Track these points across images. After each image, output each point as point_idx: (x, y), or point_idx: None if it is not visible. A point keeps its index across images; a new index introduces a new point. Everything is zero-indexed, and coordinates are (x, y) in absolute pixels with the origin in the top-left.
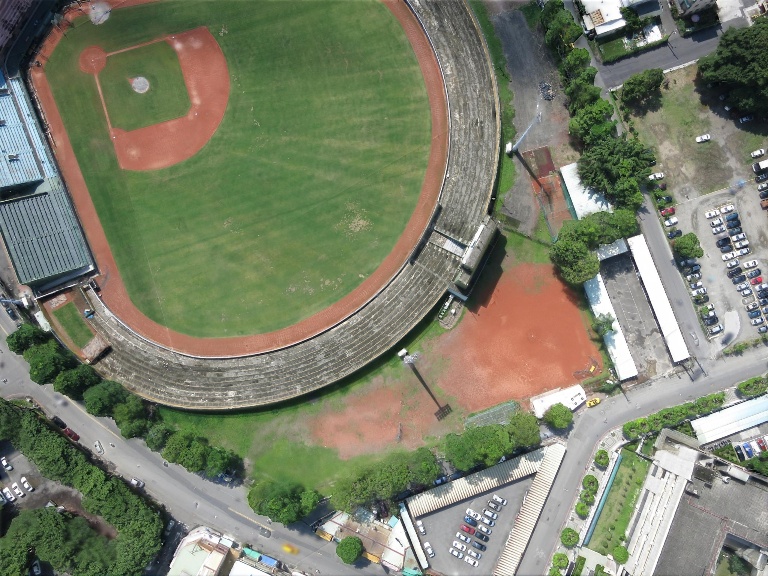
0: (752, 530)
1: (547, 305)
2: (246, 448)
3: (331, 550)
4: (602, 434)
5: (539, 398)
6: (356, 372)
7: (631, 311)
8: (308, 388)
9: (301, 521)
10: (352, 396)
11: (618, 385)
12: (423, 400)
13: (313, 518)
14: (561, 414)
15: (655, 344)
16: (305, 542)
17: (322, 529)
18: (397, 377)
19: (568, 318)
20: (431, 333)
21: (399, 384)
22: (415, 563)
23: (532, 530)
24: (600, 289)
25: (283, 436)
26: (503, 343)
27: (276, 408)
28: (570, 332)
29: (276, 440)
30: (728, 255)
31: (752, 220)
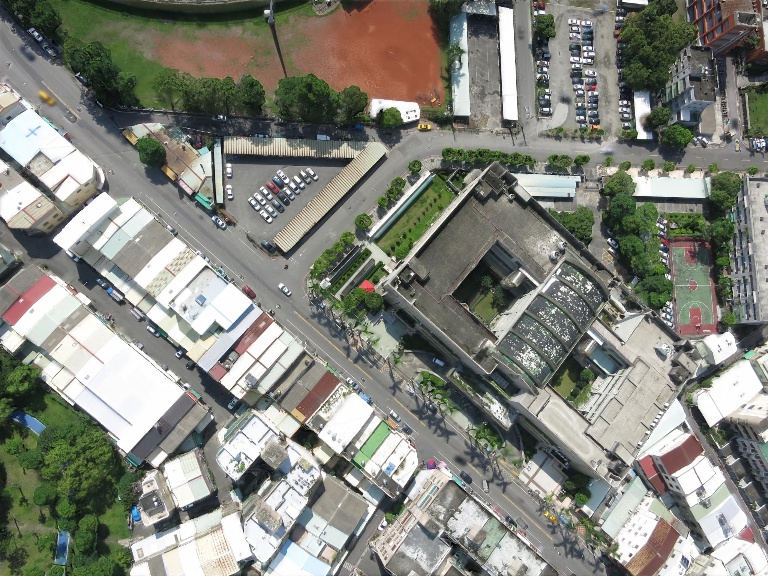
0: (518, 247)
1: (413, 33)
2: (82, 35)
3: (132, 158)
4: (423, 157)
5: (378, 99)
6: (218, 14)
7: (482, 69)
8: (166, 2)
9: (112, 121)
10: (207, 33)
11: (451, 123)
12: (273, 64)
13: (126, 123)
14: (392, 109)
15: (493, 103)
16: (109, 141)
17: (131, 129)
18: (256, 35)
19: (427, 51)
20: (302, 12)
21: (255, 41)
22: (211, 193)
23: (332, 207)
24: (462, 35)
25: (124, 39)
26: (363, 47)
27: (127, 12)
28: (425, 63)
29: (116, 40)
30: (575, 58)
31: (603, 42)
